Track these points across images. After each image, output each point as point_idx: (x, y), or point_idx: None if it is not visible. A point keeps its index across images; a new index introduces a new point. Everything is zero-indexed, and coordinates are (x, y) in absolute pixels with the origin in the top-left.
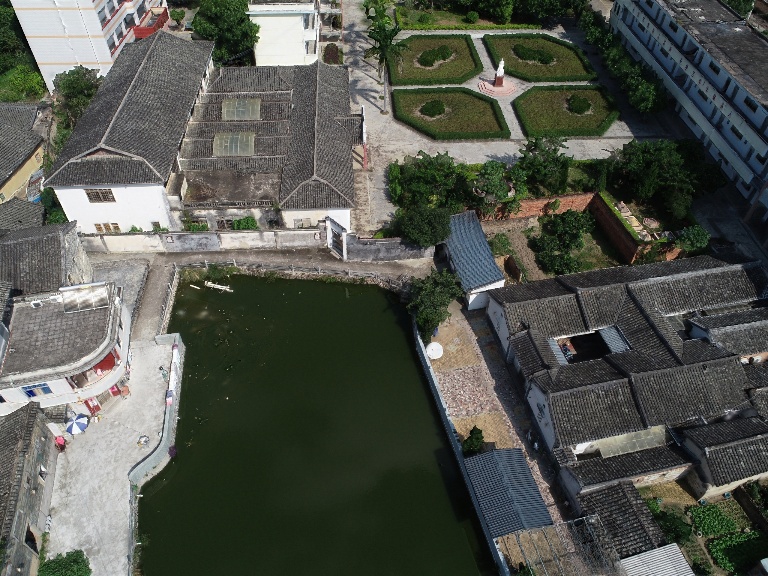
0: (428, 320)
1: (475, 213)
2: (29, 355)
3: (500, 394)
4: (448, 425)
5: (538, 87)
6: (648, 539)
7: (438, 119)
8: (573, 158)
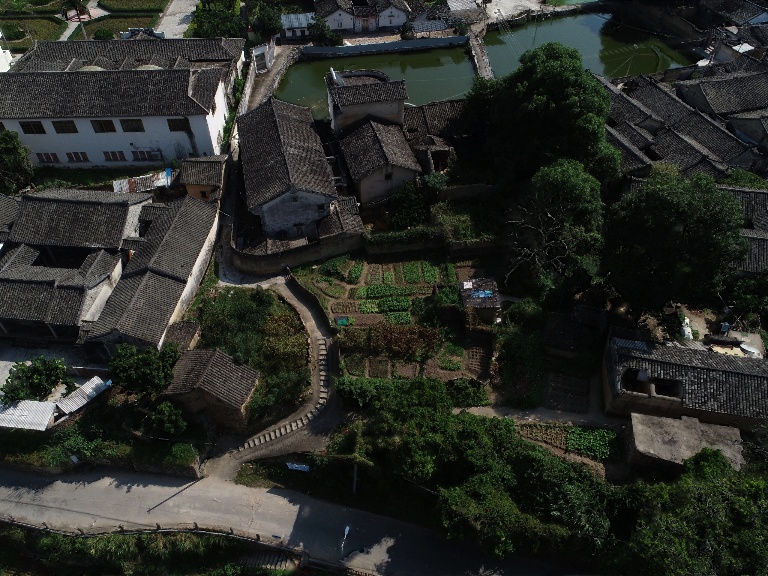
0: None
1: None
2: None
3: (372, 37)
4: (391, 45)
5: (101, 1)
6: (445, 6)
7: (119, 36)
8: (194, 3)
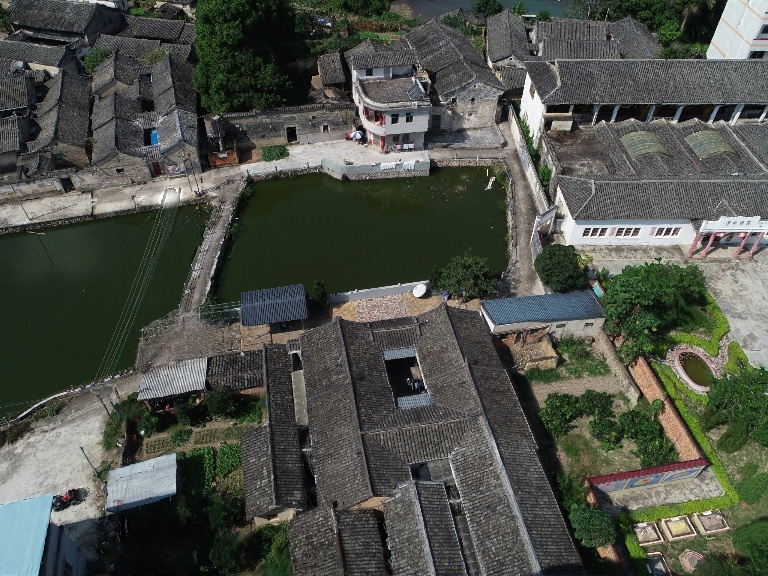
0: (441, 274)
1: (602, 315)
2: (375, 87)
3: None
4: None
5: None
6: None
7: None
8: None
